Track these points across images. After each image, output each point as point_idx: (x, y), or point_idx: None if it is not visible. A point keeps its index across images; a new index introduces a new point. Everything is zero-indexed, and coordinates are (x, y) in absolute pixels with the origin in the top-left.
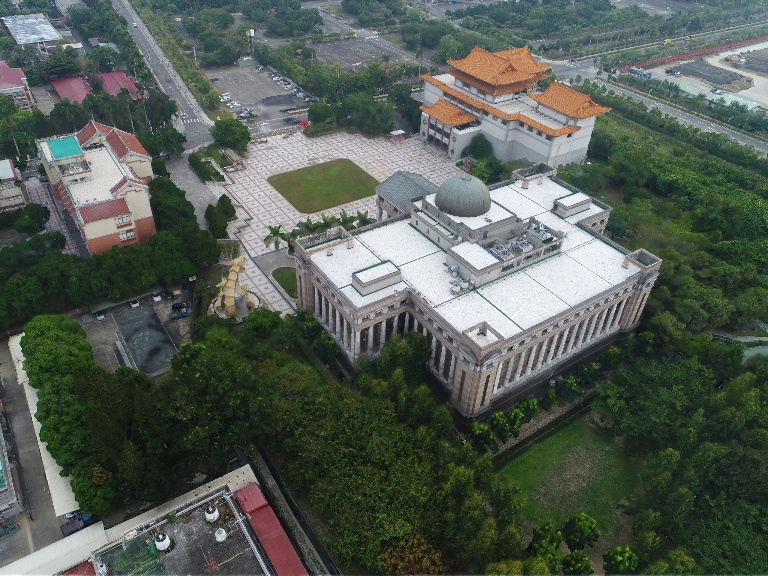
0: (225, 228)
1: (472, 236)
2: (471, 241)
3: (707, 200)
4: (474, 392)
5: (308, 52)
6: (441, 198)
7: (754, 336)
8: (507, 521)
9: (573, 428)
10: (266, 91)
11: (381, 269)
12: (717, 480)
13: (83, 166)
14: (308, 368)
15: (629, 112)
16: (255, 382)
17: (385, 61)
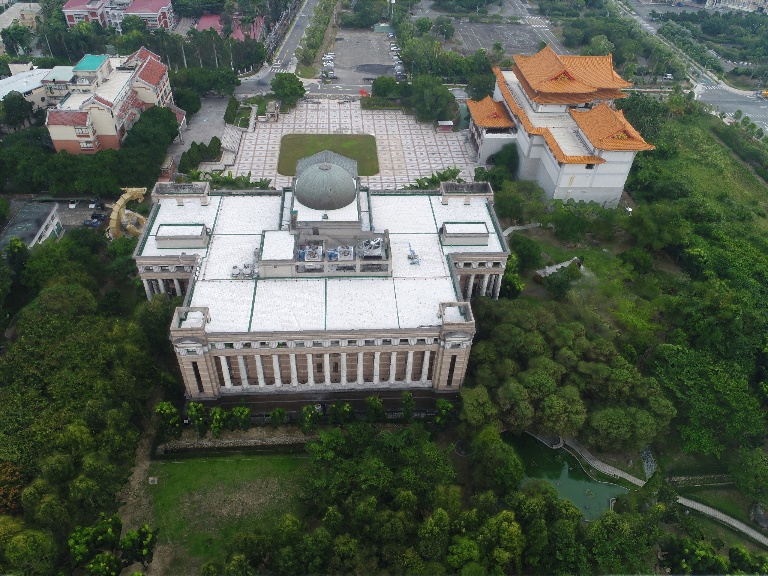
0: (194, 166)
1: (296, 227)
2: (290, 231)
3: (699, 290)
4: (184, 373)
5: (445, 28)
6: (297, 181)
7: (621, 470)
8: (70, 492)
9: (292, 459)
10: (373, 58)
11: (187, 229)
12: (311, 574)
13: None
14: (86, 295)
15: (764, 167)
16: (3, 284)
17: (496, 49)
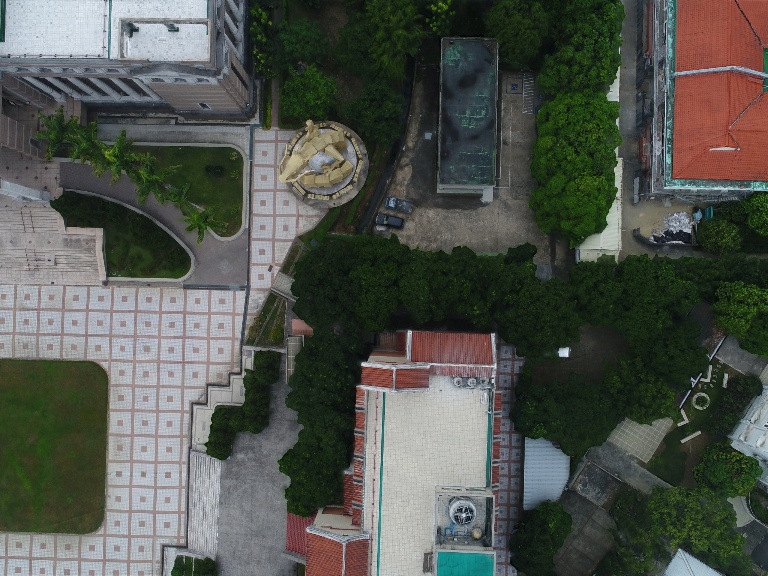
0: None
1: None
2: None
3: None
4: None
5: None
6: None
7: None
8: None
9: None
10: None
11: None
12: None
13: (443, 541)
14: None
15: None
16: None
17: None
